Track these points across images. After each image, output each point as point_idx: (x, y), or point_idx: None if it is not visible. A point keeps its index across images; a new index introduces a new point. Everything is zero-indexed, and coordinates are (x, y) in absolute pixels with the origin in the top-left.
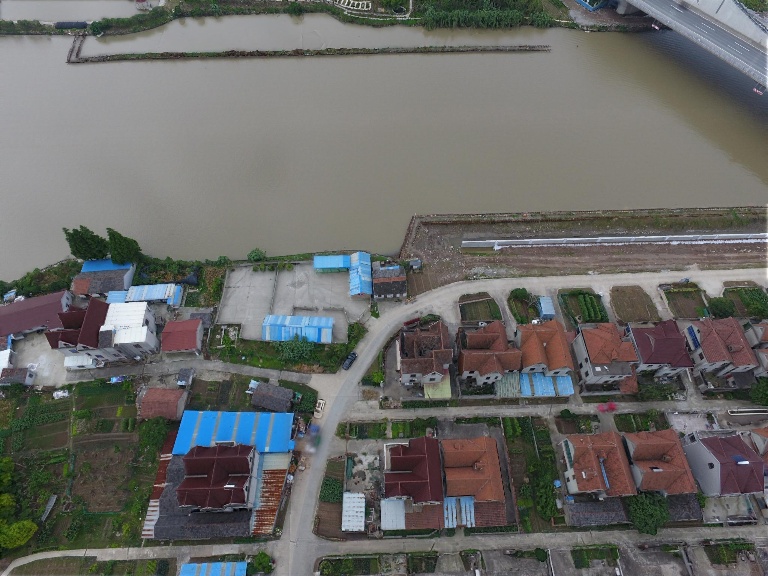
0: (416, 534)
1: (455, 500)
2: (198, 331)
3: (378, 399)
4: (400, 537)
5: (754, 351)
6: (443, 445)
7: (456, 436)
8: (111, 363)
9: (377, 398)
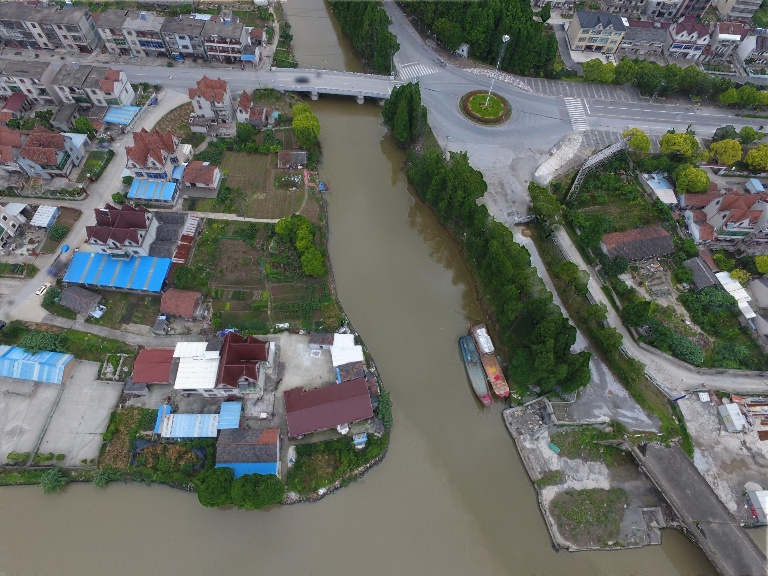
0: None
1: None
2: None
3: None
4: None
5: None
6: None
7: None
8: None
9: None
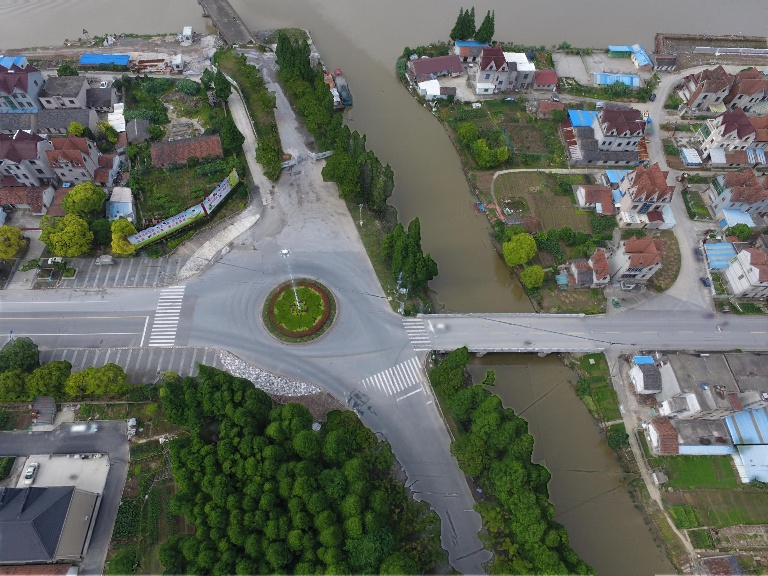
0: (730, 168)
1: (752, 150)
2: None
3: (678, 115)
4: (721, 170)
5: None
6: None
7: None
8: (501, 92)
9: (677, 115)
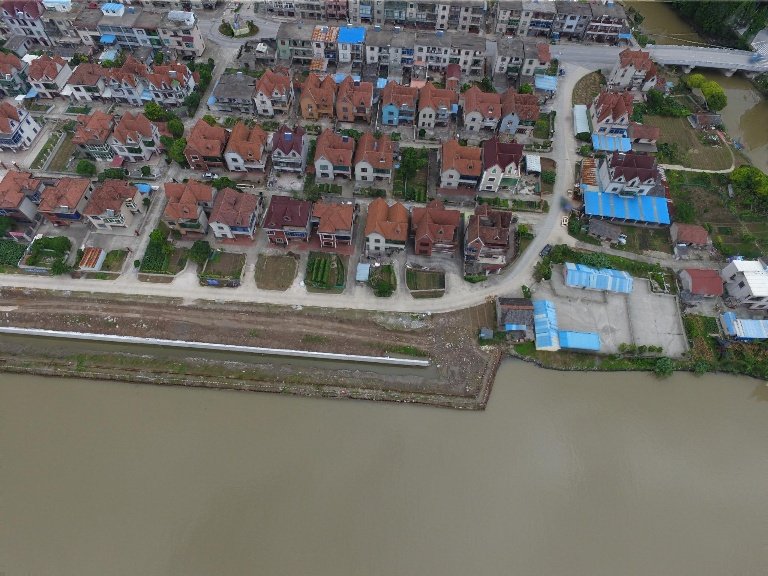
0: None
1: None
2: (690, 280)
3: None
4: None
5: (214, 201)
6: (481, 169)
7: (461, 196)
8: None
9: None
